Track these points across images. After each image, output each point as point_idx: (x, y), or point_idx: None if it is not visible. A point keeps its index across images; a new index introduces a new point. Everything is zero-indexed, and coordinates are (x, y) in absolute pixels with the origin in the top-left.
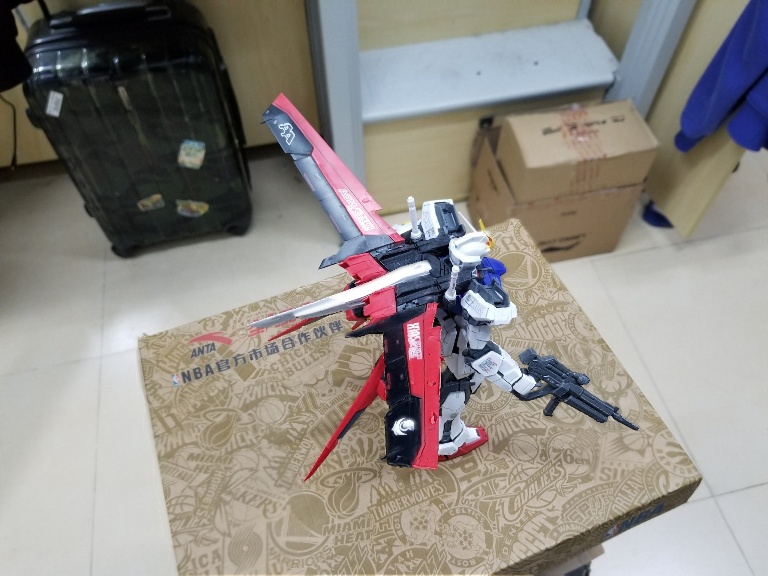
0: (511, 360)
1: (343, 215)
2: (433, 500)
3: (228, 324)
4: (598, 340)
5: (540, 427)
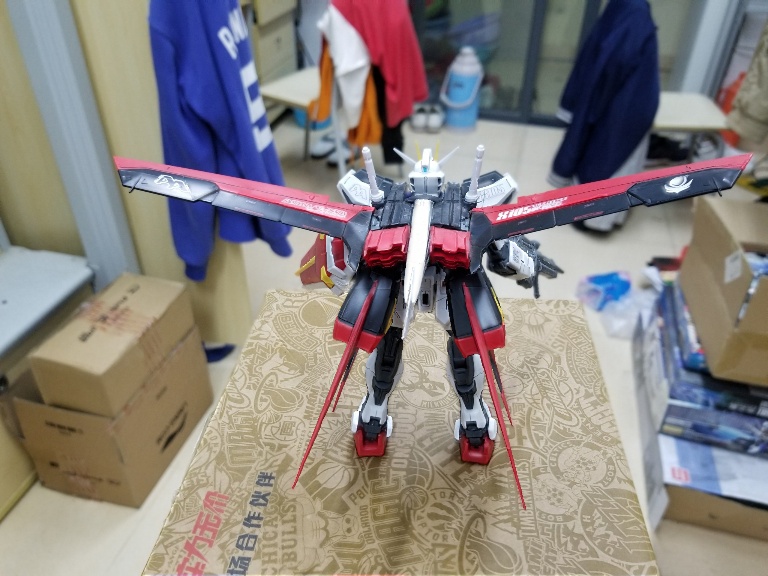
0: None
1: (313, 218)
2: (533, 475)
3: None
4: None
5: None
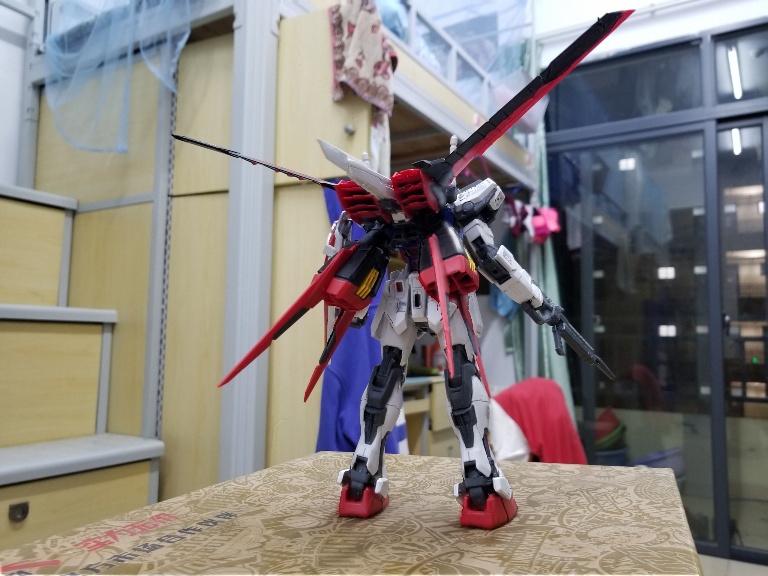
0: None
1: None
2: (549, 537)
3: (33, 552)
4: None
5: (539, 490)
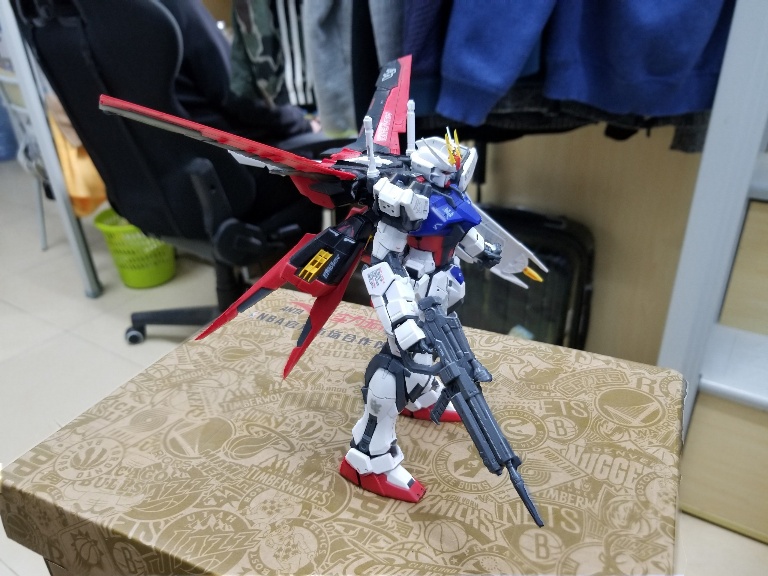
0: (406, 291)
1: None
2: (306, 502)
3: None
4: (665, 516)
5: (488, 535)
